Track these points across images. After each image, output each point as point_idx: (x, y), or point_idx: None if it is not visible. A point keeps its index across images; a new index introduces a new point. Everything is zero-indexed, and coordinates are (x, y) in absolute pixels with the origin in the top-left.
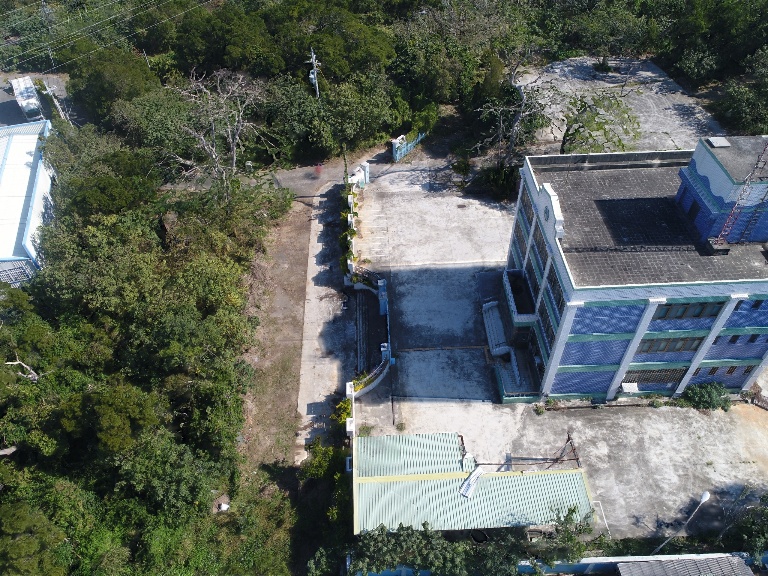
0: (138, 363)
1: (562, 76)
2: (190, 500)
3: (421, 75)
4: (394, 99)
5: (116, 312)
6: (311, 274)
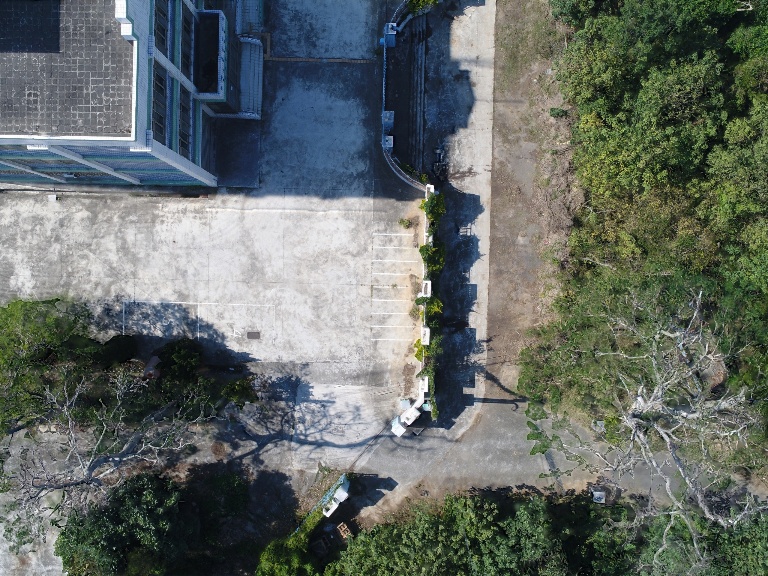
0: None
1: None
2: None
3: None
4: None
5: None
6: (485, 219)
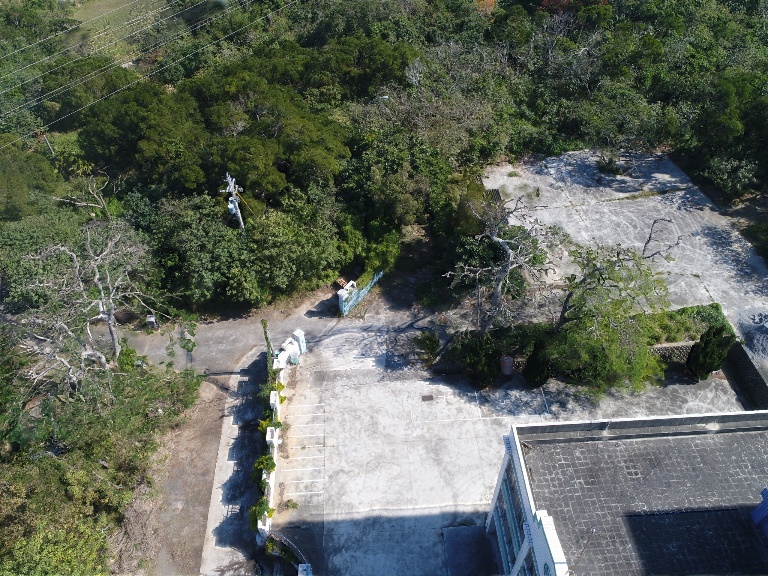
0: None
1: (559, 180)
2: None
3: (376, 200)
4: (342, 228)
5: None
6: (213, 522)
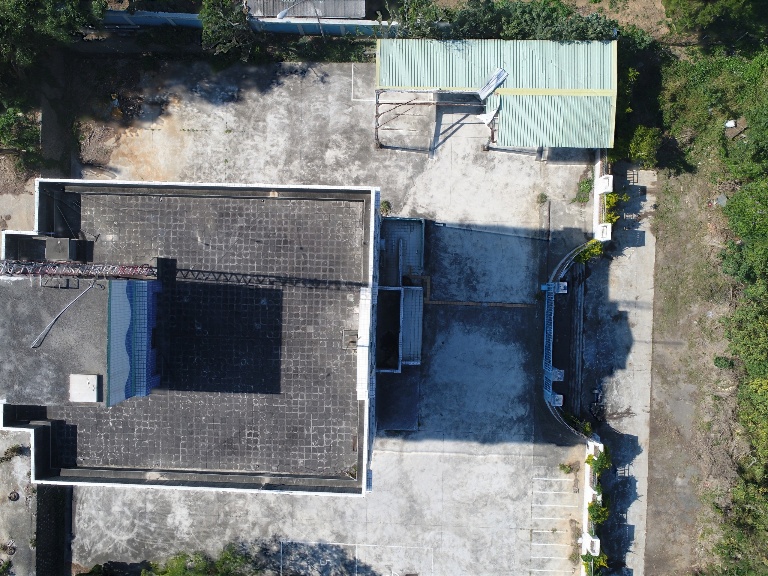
0: None
1: None
2: None
3: None
4: None
5: None
6: (643, 460)
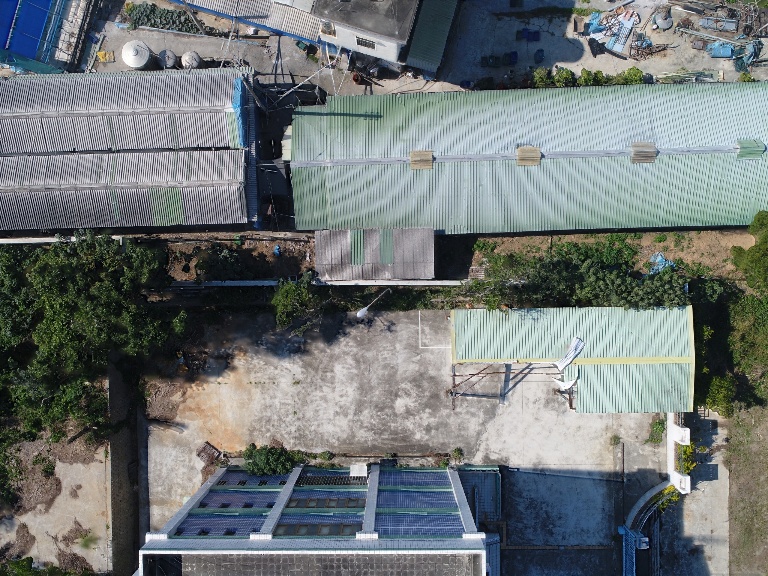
0: None
1: None
2: None
3: None
4: None
5: None
6: None
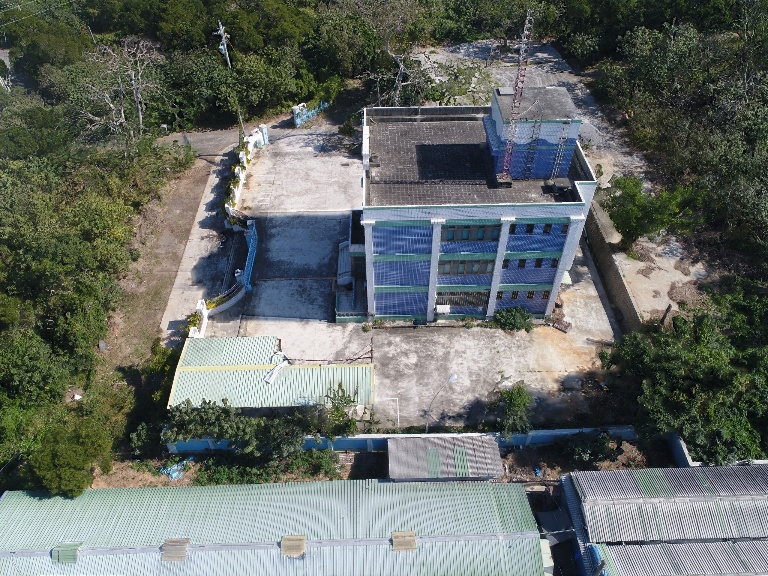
0: (24, 283)
1: (465, 56)
2: (42, 386)
3: (323, 49)
4: (300, 71)
5: (19, 246)
6: (198, 219)
